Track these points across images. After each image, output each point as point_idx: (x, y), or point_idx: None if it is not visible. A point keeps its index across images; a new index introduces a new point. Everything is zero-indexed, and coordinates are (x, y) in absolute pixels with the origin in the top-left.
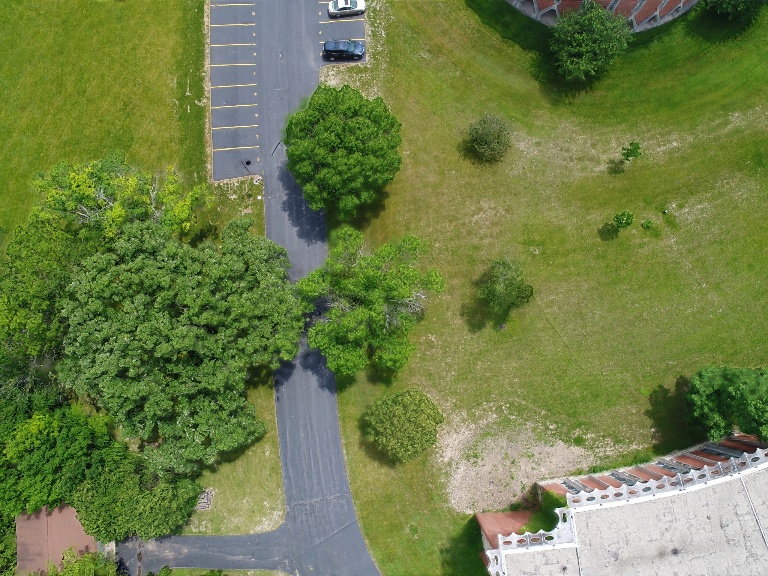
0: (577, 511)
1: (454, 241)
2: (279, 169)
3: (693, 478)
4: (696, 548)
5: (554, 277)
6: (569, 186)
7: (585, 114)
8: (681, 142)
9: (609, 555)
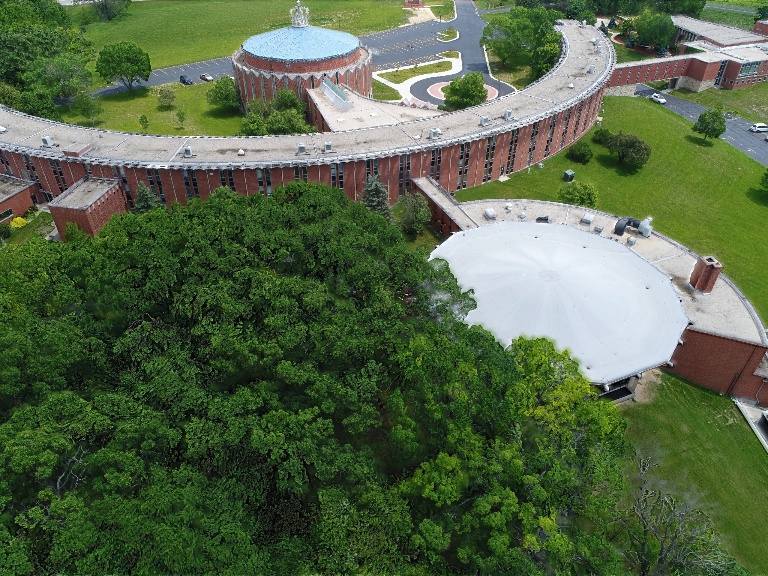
0: None
1: None
2: None
3: None
4: None
5: None
6: None
7: None
8: None
9: None
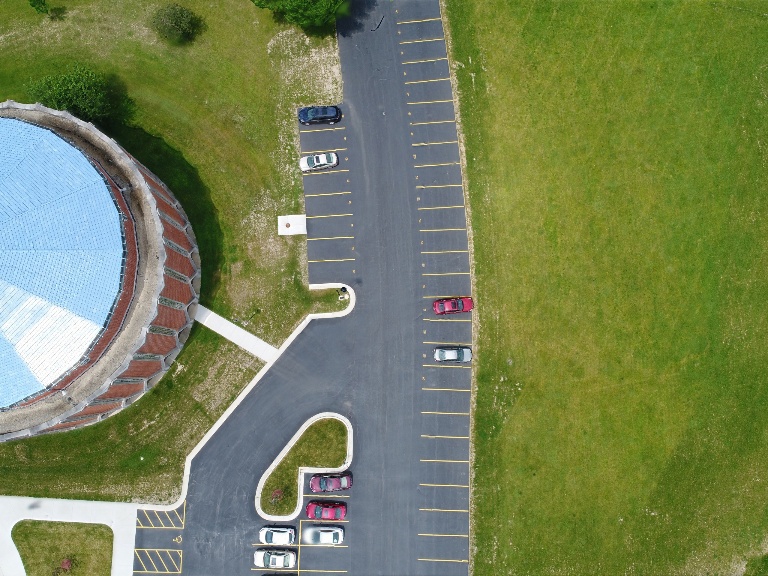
0: None
1: None
2: (376, 3)
3: None
4: None
5: None
6: None
7: None
8: None
9: None
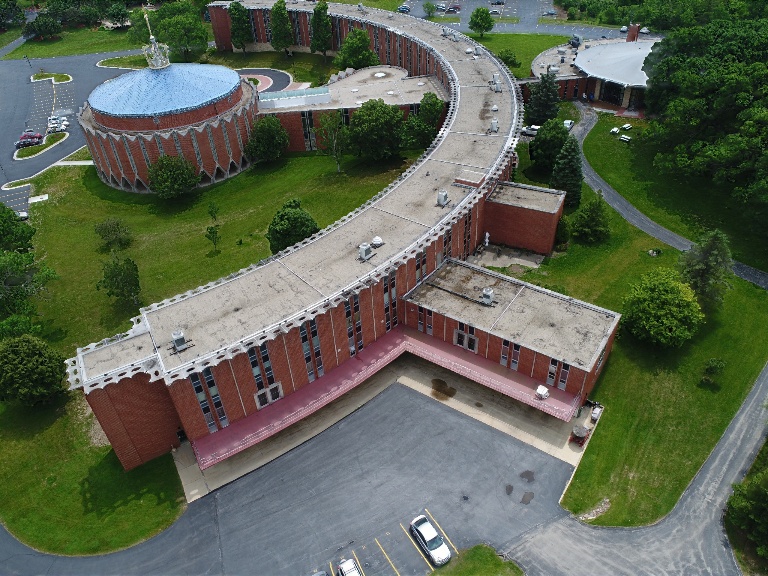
0: (147, 312)
1: (94, 291)
2: None
3: (243, 272)
4: (253, 303)
5: (176, 284)
6: (181, 244)
7: (190, 217)
8: (256, 209)
9: (179, 328)
